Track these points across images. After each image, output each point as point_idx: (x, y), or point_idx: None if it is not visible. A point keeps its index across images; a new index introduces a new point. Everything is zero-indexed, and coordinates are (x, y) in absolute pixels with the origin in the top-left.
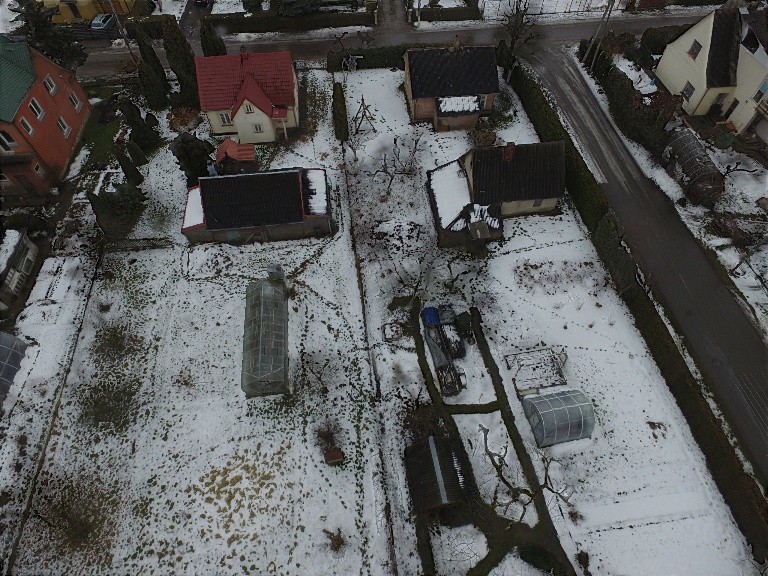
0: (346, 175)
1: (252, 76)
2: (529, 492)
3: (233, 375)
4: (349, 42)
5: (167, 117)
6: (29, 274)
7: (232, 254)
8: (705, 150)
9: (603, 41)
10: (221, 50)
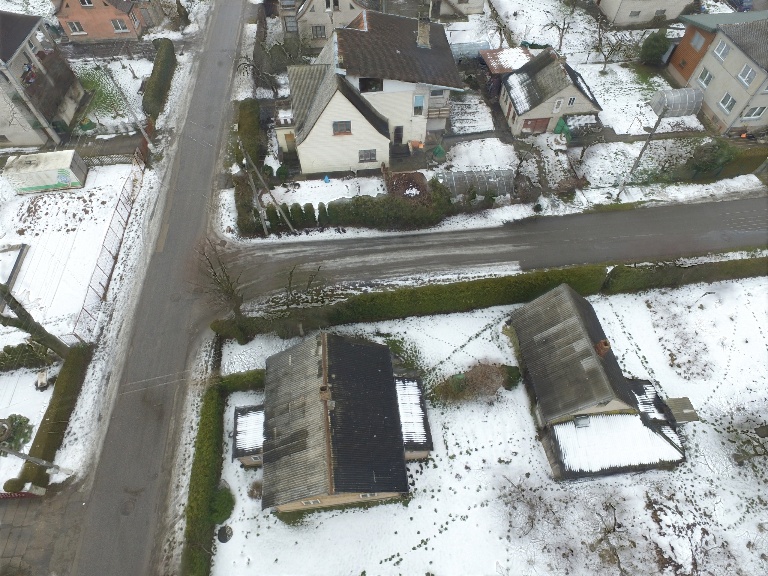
0: None
1: None
2: None
3: None
4: None
5: None
6: None
7: None
8: None
9: None
10: None
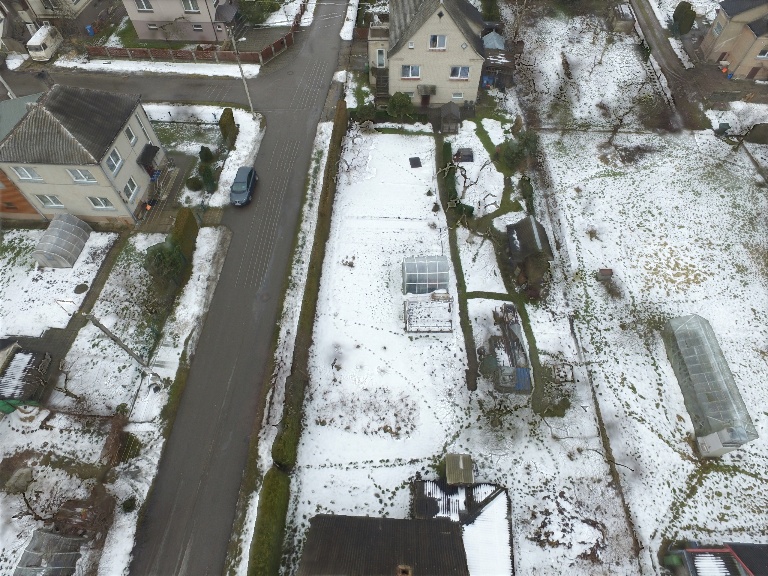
0: None
1: None
2: (468, 225)
3: None
4: None
5: None
6: None
7: None
8: None
9: None
10: None
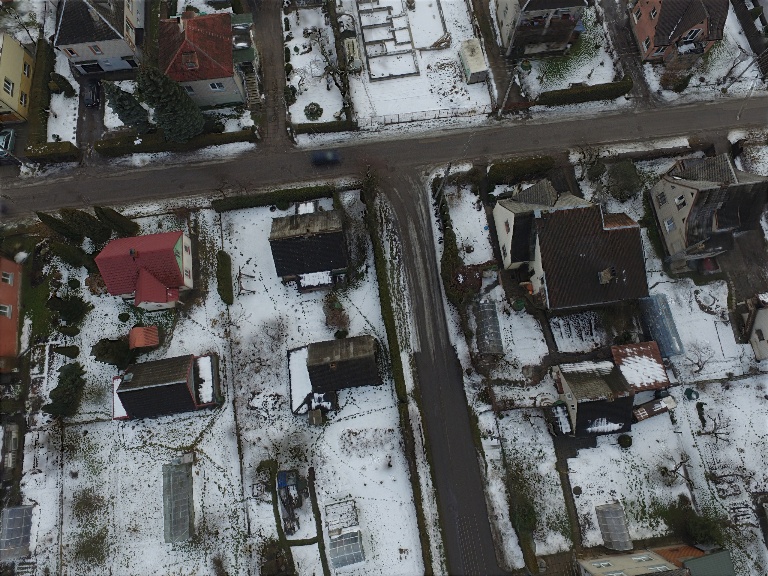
0: (231, 344)
1: (145, 269)
2: None
3: (162, 523)
4: (234, 167)
5: (85, 285)
6: (17, 448)
7: (152, 427)
8: (502, 315)
9: (453, 178)
10: (117, 221)
